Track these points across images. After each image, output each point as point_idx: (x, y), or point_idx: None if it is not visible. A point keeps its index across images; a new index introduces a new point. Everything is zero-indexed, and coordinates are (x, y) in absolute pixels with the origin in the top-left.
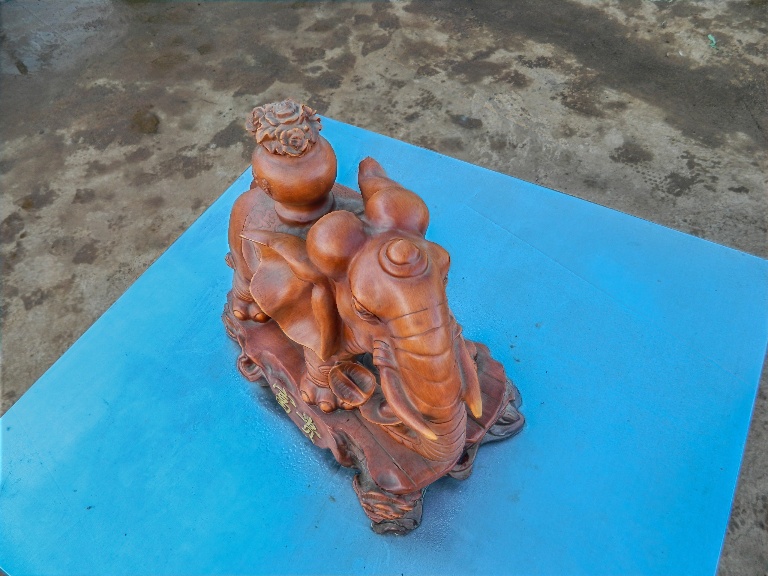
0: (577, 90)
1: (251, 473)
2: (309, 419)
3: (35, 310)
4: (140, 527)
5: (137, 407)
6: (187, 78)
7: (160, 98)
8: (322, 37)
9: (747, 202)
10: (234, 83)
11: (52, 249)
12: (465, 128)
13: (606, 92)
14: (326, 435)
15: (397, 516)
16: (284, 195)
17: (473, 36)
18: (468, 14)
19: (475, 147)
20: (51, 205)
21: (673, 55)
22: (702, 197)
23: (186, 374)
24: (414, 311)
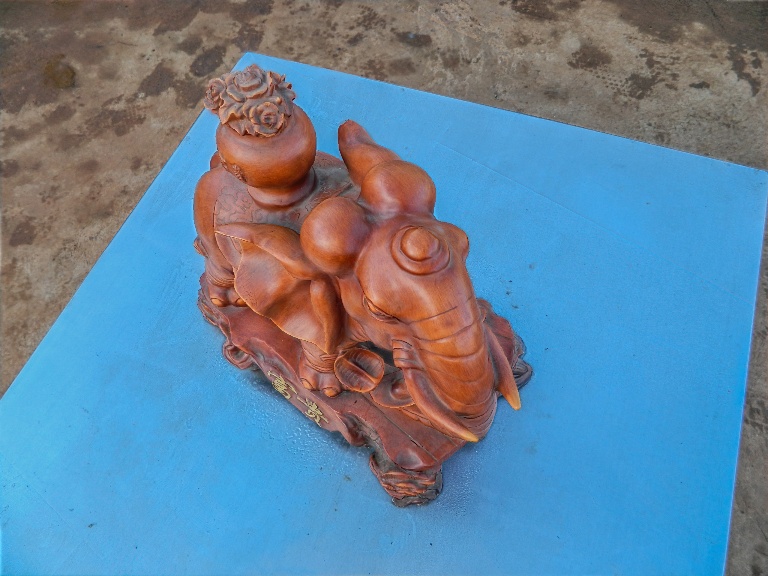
0: None
1: (258, 464)
2: (313, 405)
3: None
4: (150, 537)
5: (121, 411)
6: (97, 18)
7: (71, 45)
8: None
9: (709, 98)
10: (152, 19)
11: None
12: (414, 46)
13: None
14: (334, 419)
15: (421, 492)
16: (261, 180)
17: None
18: None
19: (427, 67)
20: None
21: None
22: (664, 97)
23: (168, 368)
24: (442, 311)
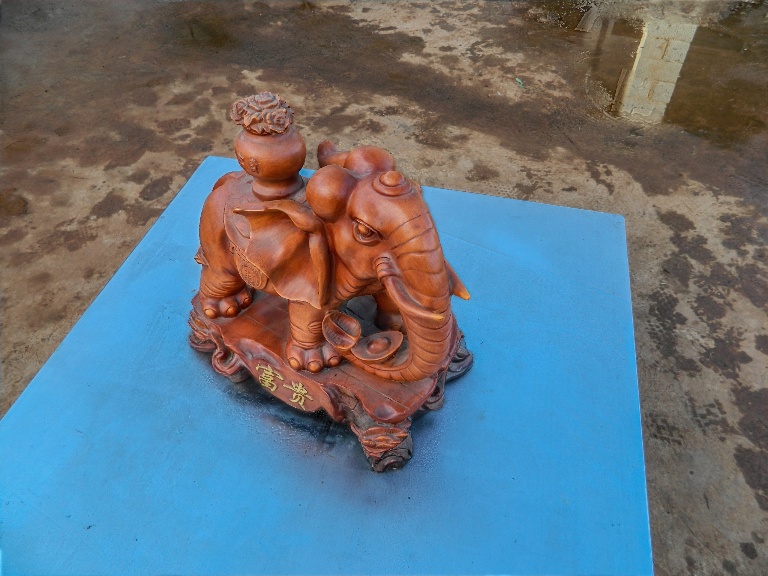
0: (425, 129)
1: (248, 455)
2: (299, 385)
3: None
4: (150, 529)
5: (114, 428)
6: (49, 159)
7: (23, 181)
8: (184, 109)
9: (578, 197)
10: (102, 158)
11: None
12: None
13: (449, 129)
14: (318, 393)
15: (397, 442)
16: (270, 170)
17: (326, 96)
18: (317, 78)
19: None
20: None
21: (493, 95)
22: (544, 198)
23: (157, 389)
24: (412, 218)
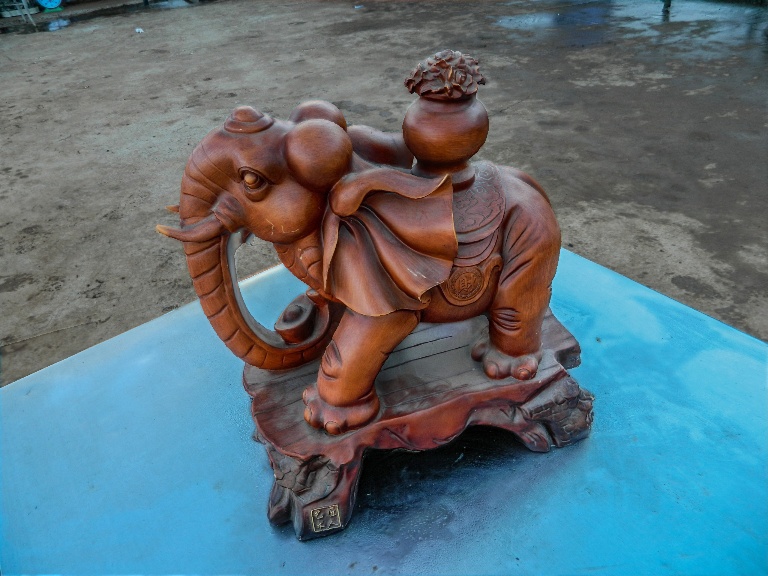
0: None
1: None
2: None
3: (715, 315)
4: None
5: None
6: None
7: None
8: None
9: None
10: None
11: None
12: None
13: None
14: None
15: None
16: None
17: None
18: None
19: None
20: None
21: None
22: None
23: None
24: None
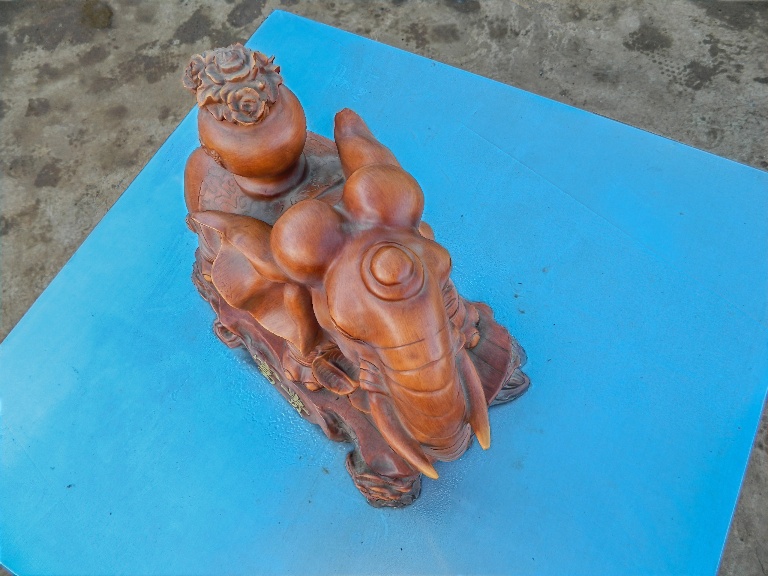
0: None
1: (238, 445)
2: (295, 396)
3: (1, 241)
4: (125, 505)
5: (110, 375)
6: None
7: None
8: None
9: None
10: None
11: (10, 171)
12: (461, 12)
13: None
14: (314, 413)
15: (394, 498)
16: (241, 169)
17: None
18: None
19: (472, 36)
20: (3, 119)
21: None
22: (724, 90)
23: (160, 336)
24: (408, 343)
